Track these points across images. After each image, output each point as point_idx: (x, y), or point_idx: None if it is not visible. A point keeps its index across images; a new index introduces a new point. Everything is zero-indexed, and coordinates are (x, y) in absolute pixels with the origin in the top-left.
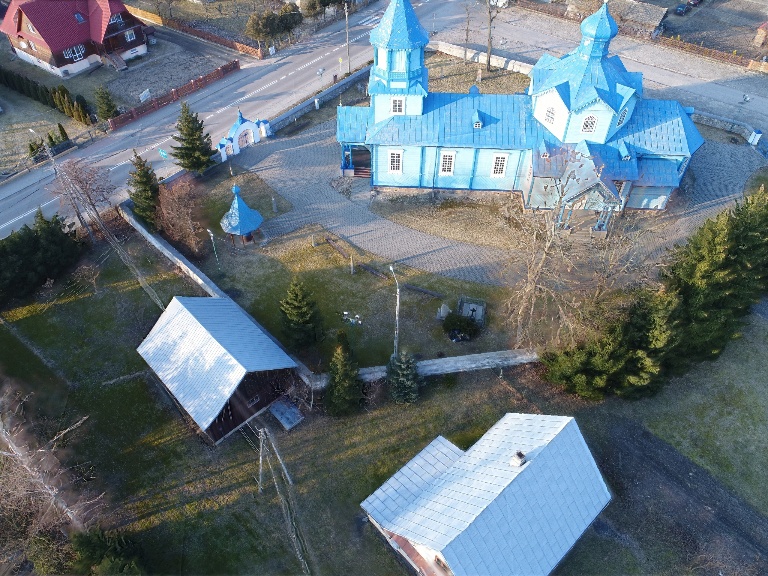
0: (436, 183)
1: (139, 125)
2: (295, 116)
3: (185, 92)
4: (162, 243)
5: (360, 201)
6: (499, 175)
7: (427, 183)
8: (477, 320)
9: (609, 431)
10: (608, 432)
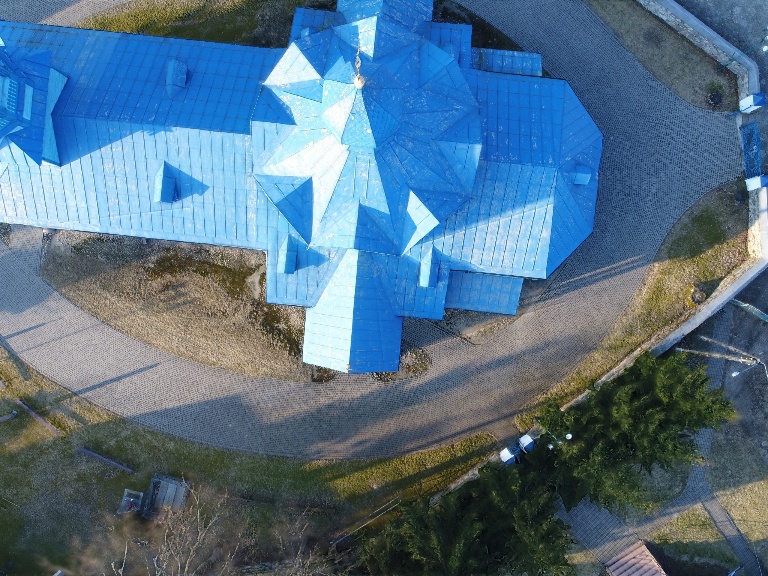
0: None
1: None
2: None
3: None
4: None
5: (25, 252)
6: None
7: None
8: (167, 525)
9: None
10: None
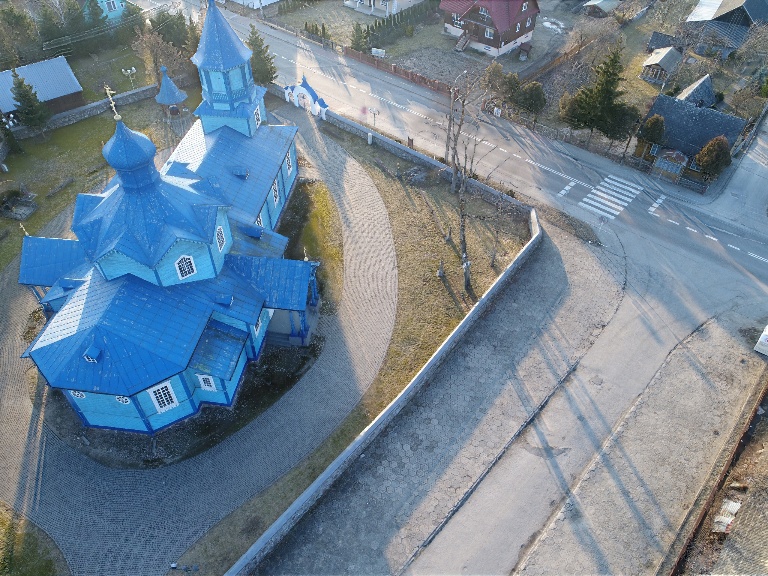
0: None
1: (353, 64)
2: (351, 129)
3: (402, 75)
4: (175, 78)
5: None
6: None
7: None
8: (2, 206)
9: None
10: None
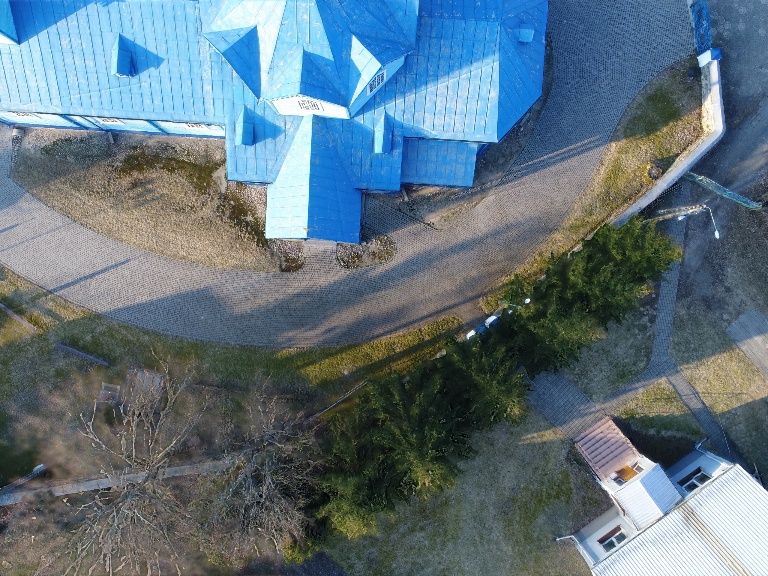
0: (107, 127)
1: None
2: None
3: None
4: None
5: None
6: (199, 128)
7: (93, 126)
8: None
9: (279, 554)
10: (277, 556)
